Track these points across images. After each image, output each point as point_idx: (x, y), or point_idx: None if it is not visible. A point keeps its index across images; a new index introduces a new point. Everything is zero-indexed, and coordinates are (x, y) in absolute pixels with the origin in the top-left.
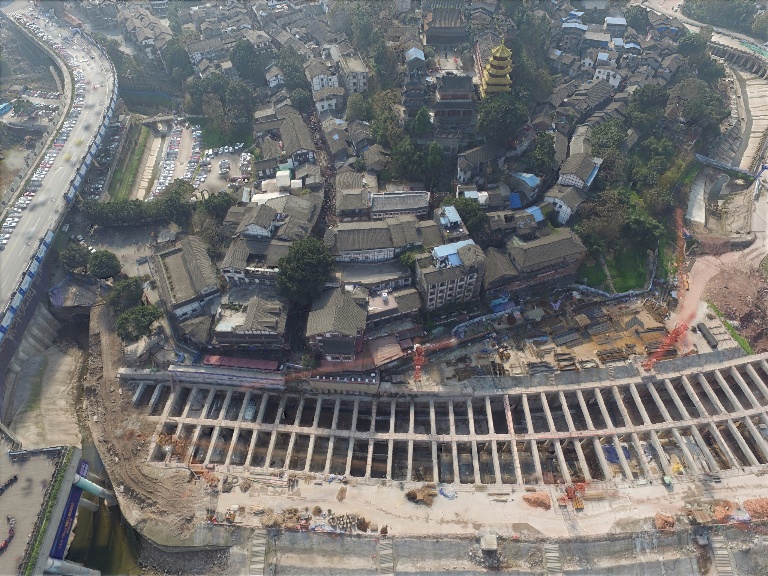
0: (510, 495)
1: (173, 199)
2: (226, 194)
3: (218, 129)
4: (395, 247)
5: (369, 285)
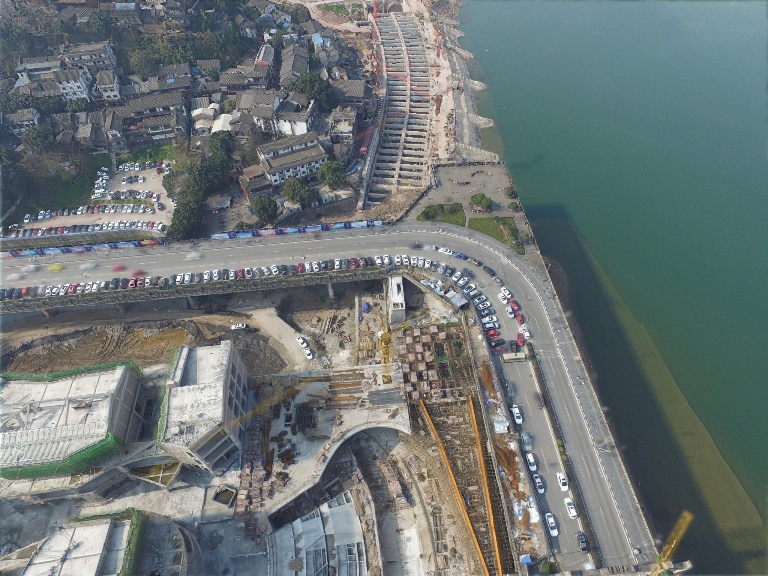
0: (435, 80)
1: (201, 168)
2: (215, 133)
3: (70, 179)
4: (308, 58)
5: (329, 78)
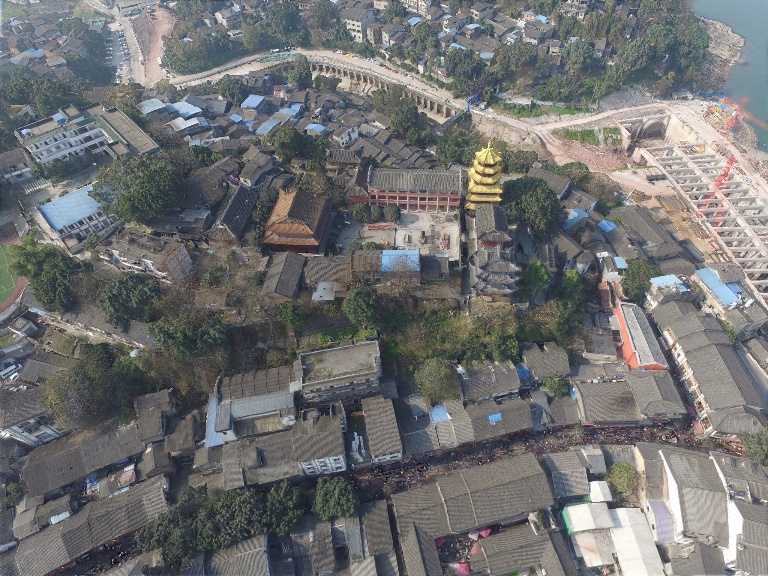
0: None
1: None
2: None
3: None
4: None
5: None
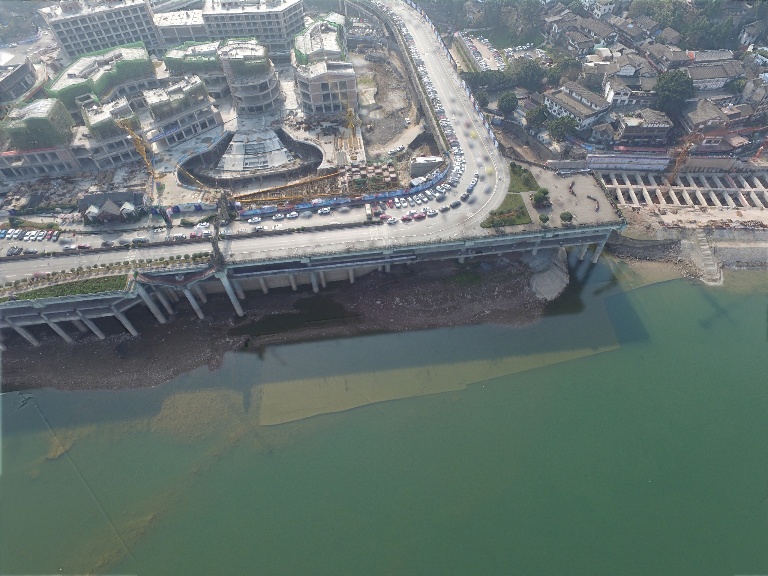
0: None
1: (533, 65)
2: (575, 59)
3: (512, 33)
4: (729, 77)
5: (716, 101)
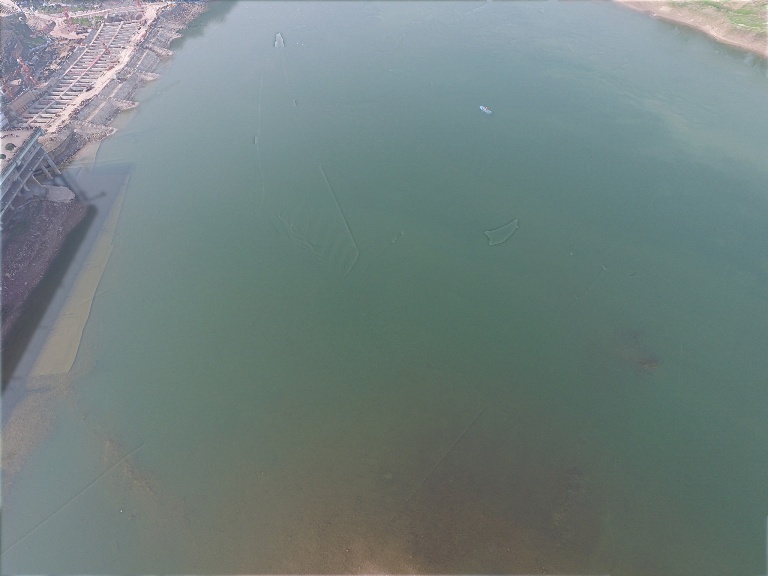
0: None
1: None
2: None
3: None
4: None
5: None
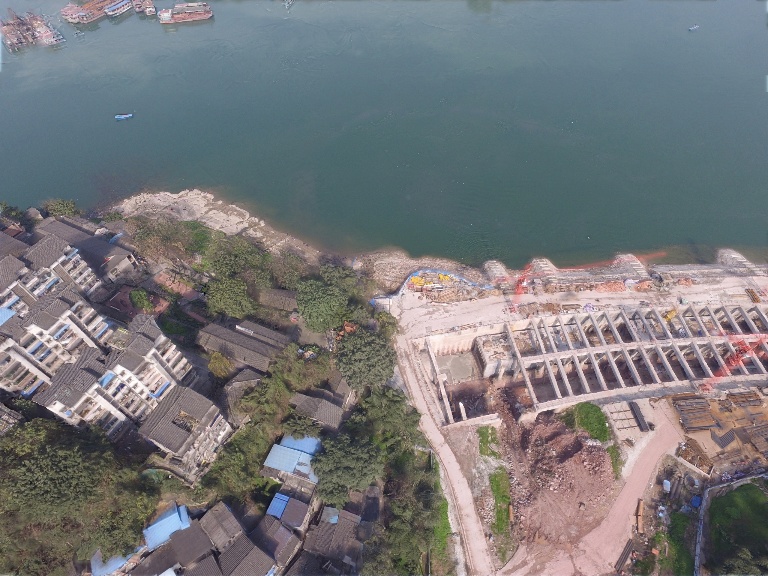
0: None
1: None
2: None
3: None
4: None
5: None
